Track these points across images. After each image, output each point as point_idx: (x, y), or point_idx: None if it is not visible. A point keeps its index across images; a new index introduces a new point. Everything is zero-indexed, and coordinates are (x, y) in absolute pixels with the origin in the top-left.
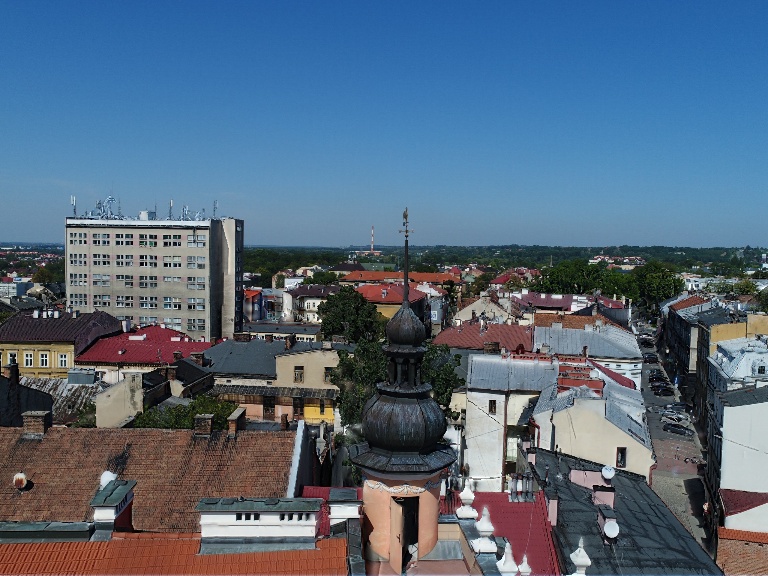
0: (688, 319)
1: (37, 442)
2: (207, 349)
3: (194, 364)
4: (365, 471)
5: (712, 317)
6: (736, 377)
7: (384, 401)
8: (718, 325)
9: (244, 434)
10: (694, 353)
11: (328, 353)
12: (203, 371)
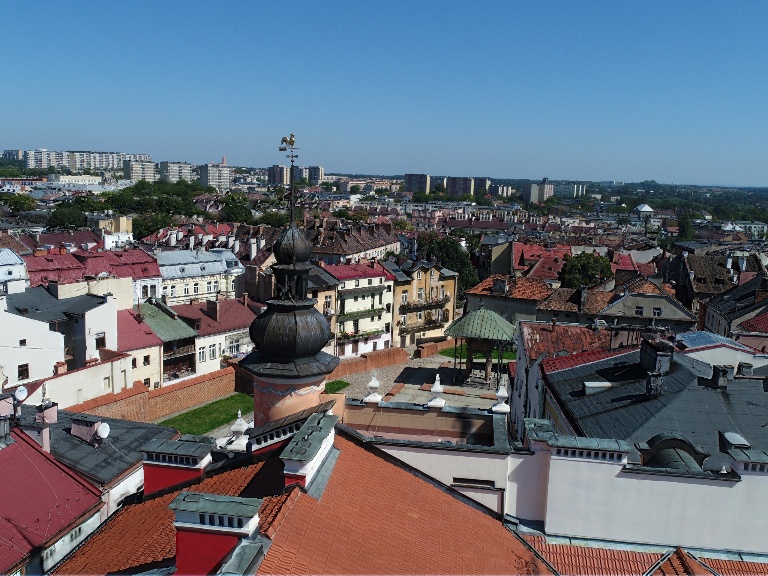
0: None
1: None
2: None
3: None
4: (295, 384)
5: None
6: None
7: (303, 315)
8: None
9: None
10: None
11: None
12: None
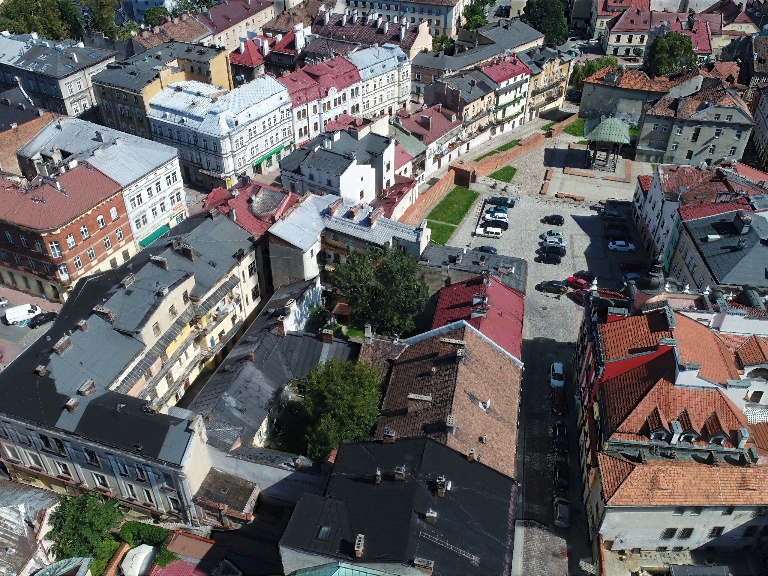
0: (38, 71)
1: (458, 429)
2: (56, 380)
3: (94, 396)
4: None
5: (107, 75)
6: (225, 134)
7: (660, 278)
8: (146, 88)
9: (465, 345)
10: (68, 102)
11: (168, 297)
12: (107, 393)
